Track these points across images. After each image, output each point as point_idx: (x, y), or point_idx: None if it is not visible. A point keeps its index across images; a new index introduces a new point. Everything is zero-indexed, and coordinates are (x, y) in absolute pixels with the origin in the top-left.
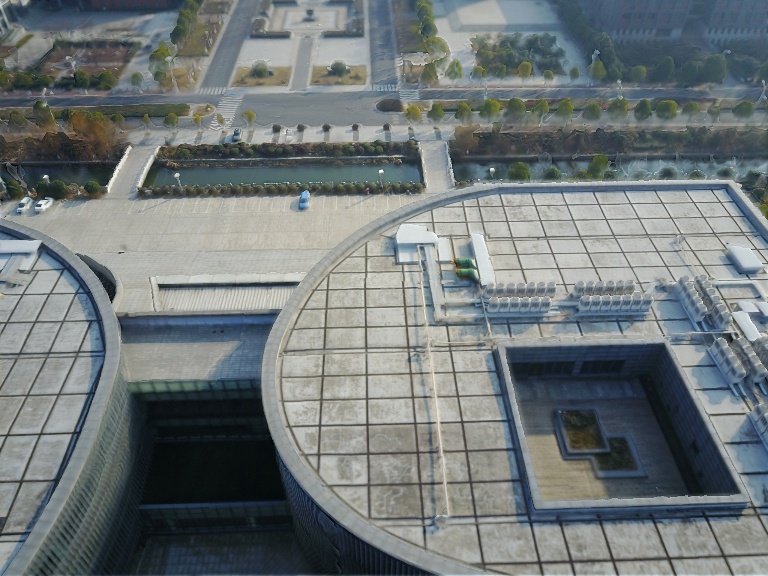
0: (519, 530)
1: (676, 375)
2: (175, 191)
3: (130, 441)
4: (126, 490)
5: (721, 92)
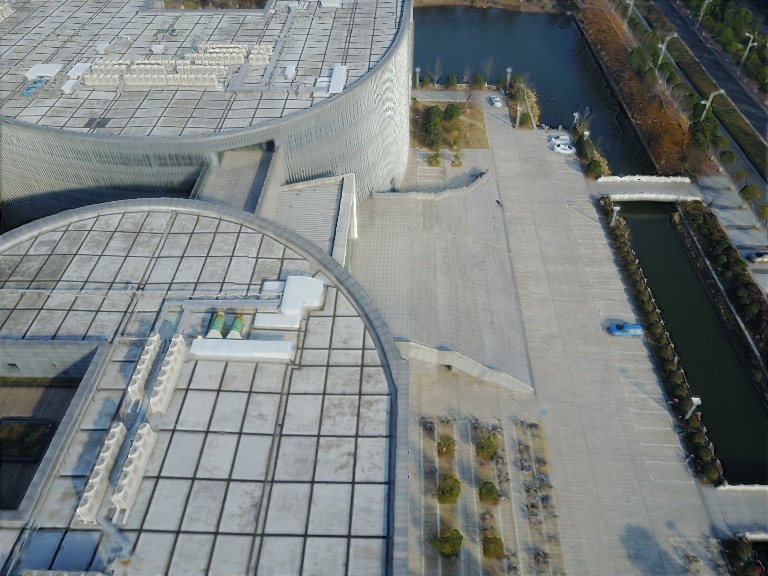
0: None
1: None
2: None
3: (184, 186)
4: None
5: None
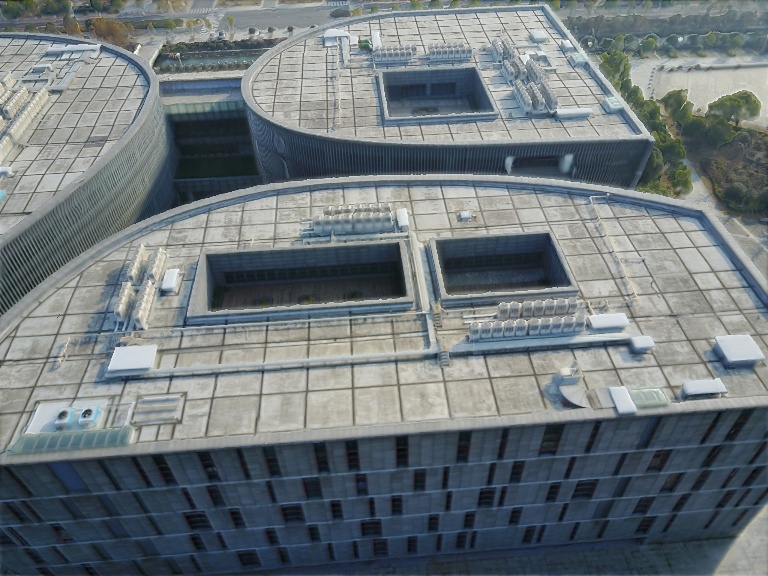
0: (377, 129)
1: (478, 79)
2: (177, 68)
3: (166, 138)
4: (166, 161)
5: None
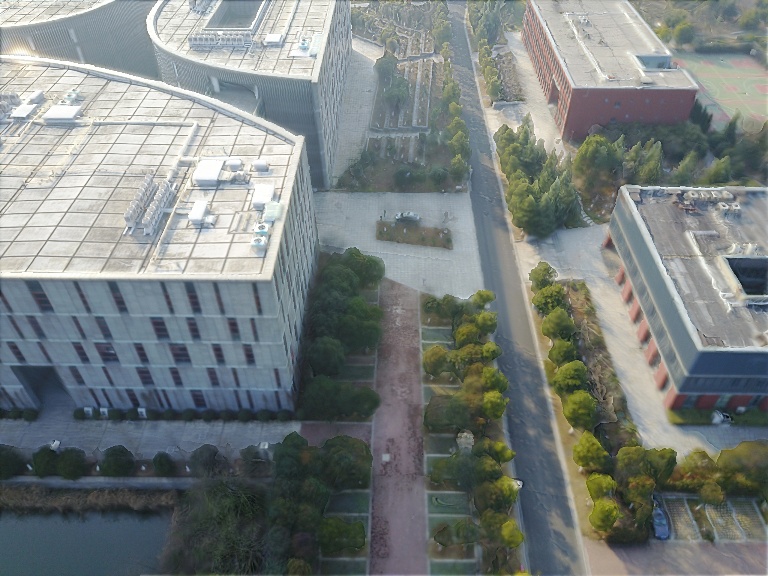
0: None
1: None
2: None
3: None
4: None
5: None
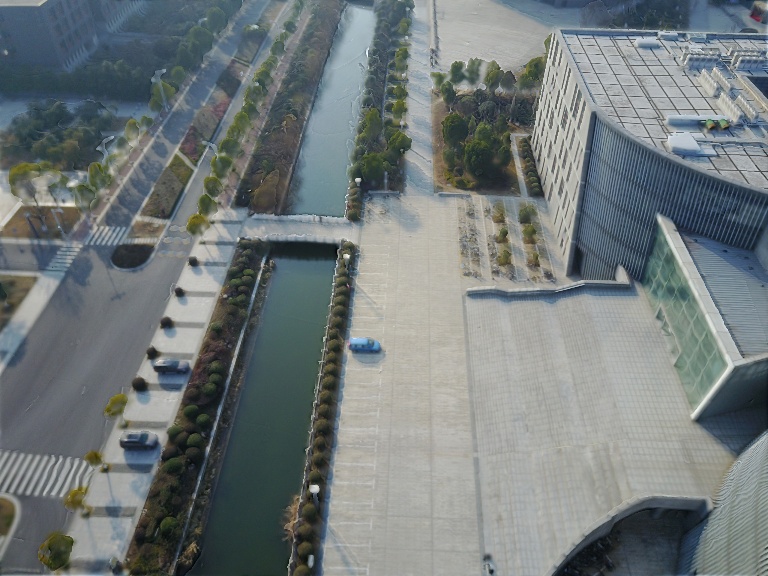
0: None
1: (767, 80)
2: (312, 517)
3: None
4: None
5: (219, 55)
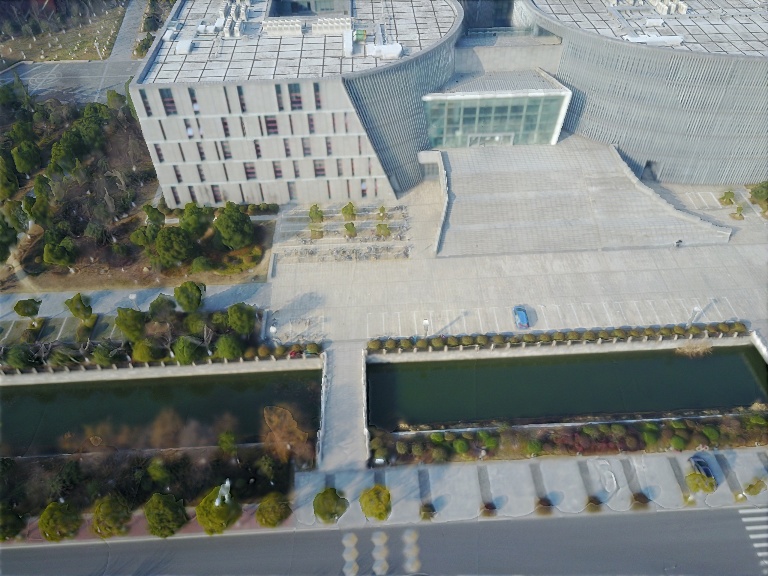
0: None
1: None
2: None
3: None
4: None
5: None
